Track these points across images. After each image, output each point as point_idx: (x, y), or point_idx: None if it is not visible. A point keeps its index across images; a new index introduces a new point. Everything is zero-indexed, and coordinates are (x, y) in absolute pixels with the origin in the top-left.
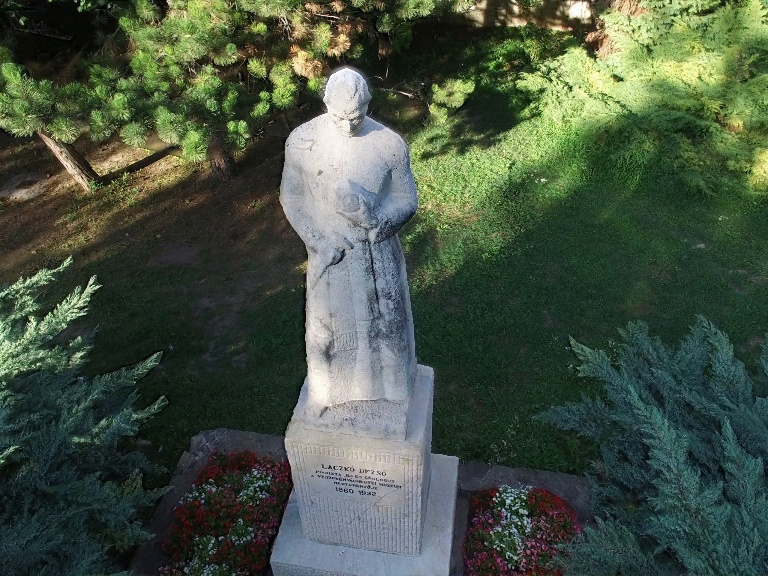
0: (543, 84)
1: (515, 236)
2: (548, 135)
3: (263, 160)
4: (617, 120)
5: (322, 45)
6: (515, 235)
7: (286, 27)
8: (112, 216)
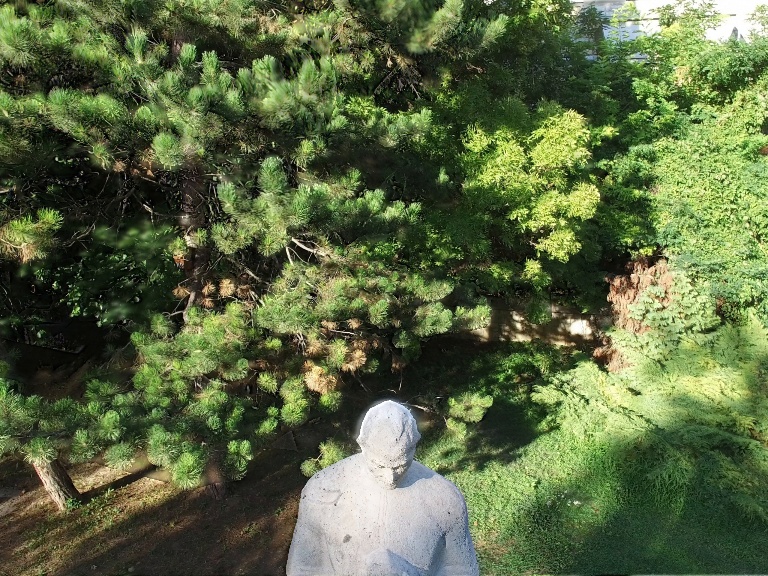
0: (559, 397)
1: (555, 574)
2: (571, 450)
3: (263, 476)
4: (646, 436)
5: (337, 360)
6: (554, 572)
7: (301, 342)
8: (82, 542)
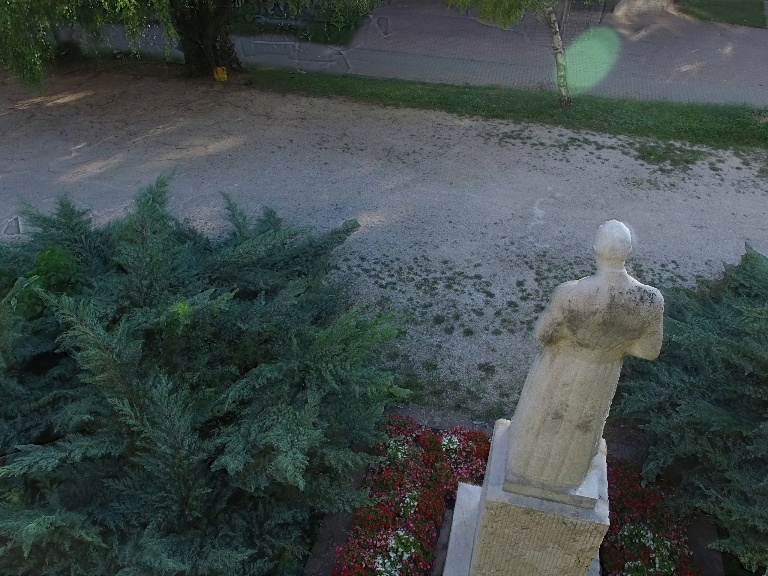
0: None
1: None
2: None
3: None
4: None
5: None
6: None
7: None
8: None
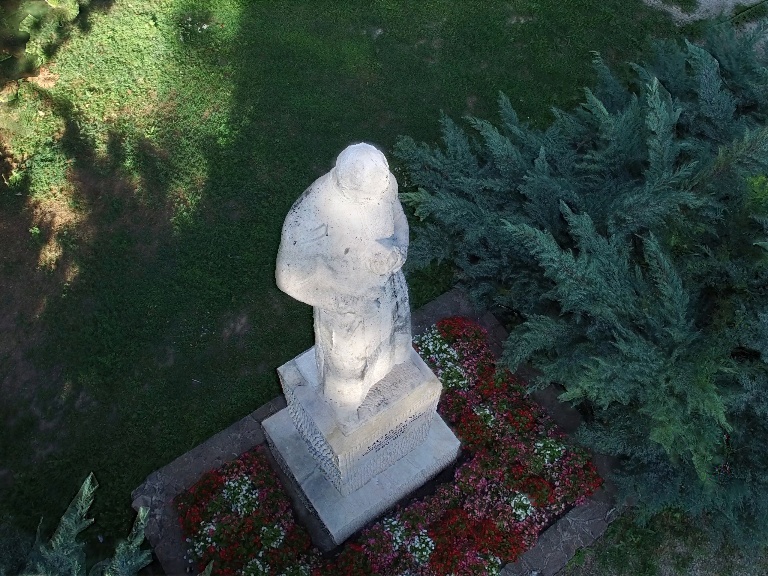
0: None
1: (227, 104)
2: None
3: None
4: None
5: None
6: (226, 103)
7: None
8: None
